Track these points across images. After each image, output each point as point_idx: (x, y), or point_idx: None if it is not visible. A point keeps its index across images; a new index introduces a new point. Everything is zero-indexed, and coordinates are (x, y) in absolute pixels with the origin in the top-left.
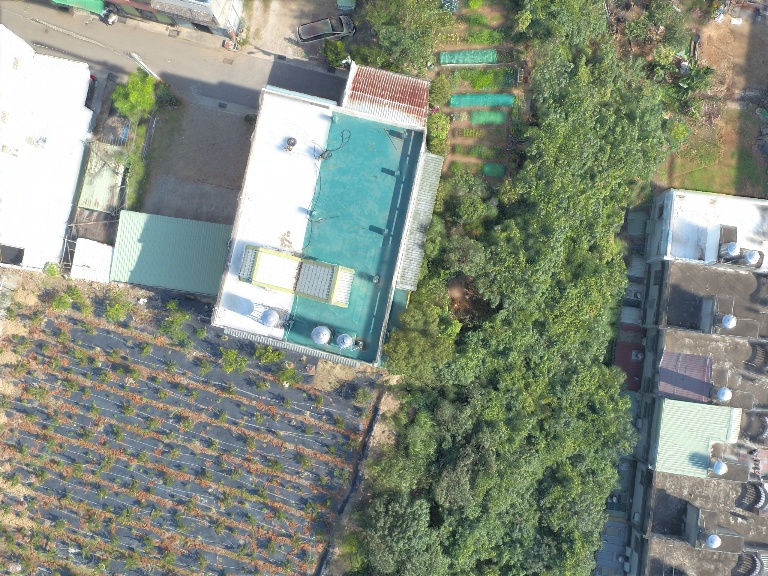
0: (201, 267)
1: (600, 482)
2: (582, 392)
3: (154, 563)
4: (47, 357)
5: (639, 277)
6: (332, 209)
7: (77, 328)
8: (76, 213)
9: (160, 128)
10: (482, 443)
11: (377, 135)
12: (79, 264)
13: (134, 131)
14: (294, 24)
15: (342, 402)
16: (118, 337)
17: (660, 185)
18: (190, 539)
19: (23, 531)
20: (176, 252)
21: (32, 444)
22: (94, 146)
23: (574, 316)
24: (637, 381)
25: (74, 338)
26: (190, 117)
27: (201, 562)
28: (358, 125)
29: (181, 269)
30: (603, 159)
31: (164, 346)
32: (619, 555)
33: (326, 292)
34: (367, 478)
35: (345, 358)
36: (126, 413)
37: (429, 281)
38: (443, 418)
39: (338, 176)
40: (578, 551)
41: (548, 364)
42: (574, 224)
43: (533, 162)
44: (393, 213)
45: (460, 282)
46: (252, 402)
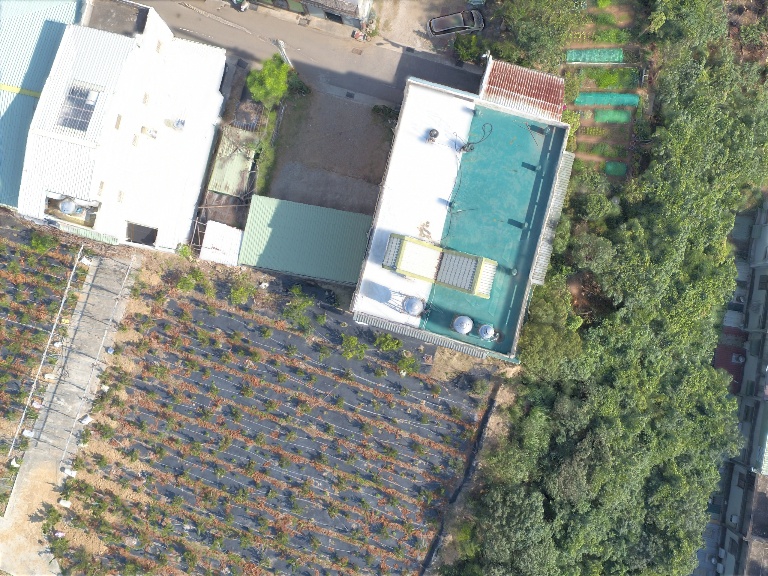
0: (329, 254)
1: (704, 483)
2: (691, 393)
3: (267, 543)
4: (169, 336)
5: (742, 281)
6: (471, 201)
7: (199, 309)
8: (206, 196)
9: (288, 115)
10: (600, 439)
11: (518, 130)
12: (208, 246)
13: (267, 117)
14: (423, 17)
15: (458, 393)
16: (239, 320)
17: (763, 190)
18: (303, 521)
19: (140, 506)
20: (305, 238)
21: (151, 421)
22: (226, 131)
23: (687, 317)
24: (737, 384)
25: (196, 319)
26: (318, 105)
27: (315, 544)
28: (500, 119)
29: (309, 255)
30: (721, 162)
31: (284, 330)
32: (712, 556)
33: (469, 283)
34: (480, 469)
35: (482, 349)
36: (245, 395)
37: (552, 276)
38: (563, 412)
39: (478, 169)
40: (685, 550)
41: (661, 363)
42: (695, 225)
43: (659, 162)
44: (532, 207)
45: (578, 279)
46: (369, 389)
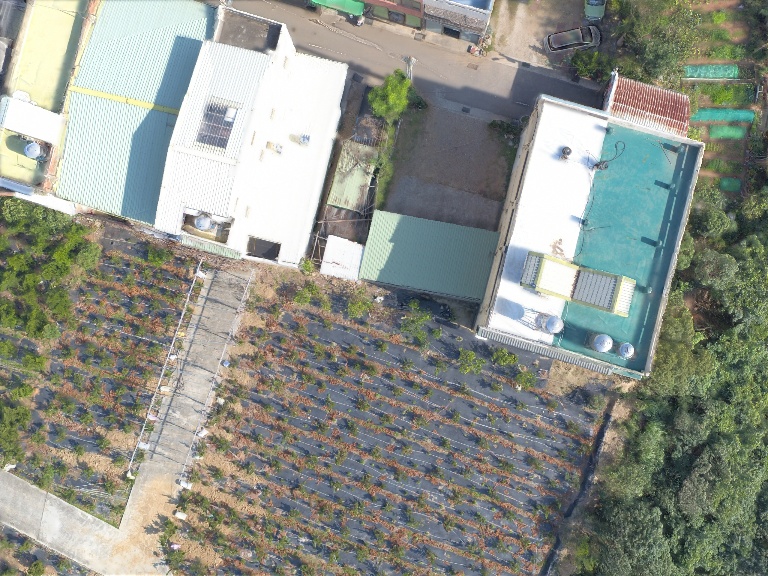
0: (450, 269)
1: None
2: None
3: (382, 556)
4: (284, 350)
5: None
6: (604, 219)
7: (314, 323)
8: (325, 210)
9: (404, 130)
10: (719, 454)
11: (651, 148)
12: (329, 261)
13: (387, 132)
14: (539, 32)
15: (573, 407)
16: (354, 333)
17: None
18: (418, 534)
19: (256, 519)
20: (426, 253)
21: (267, 434)
22: (346, 145)
23: None
24: None
25: (311, 332)
26: (433, 120)
27: (432, 557)
28: (632, 137)
29: (430, 270)
30: None
31: (399, 344)
32: None
33: (608, 301)
34: (596, 483)
35: (617, 366)
36: (361, 408)
37: (672, 292)
38: (683, 428)
39: (611, 187)
40: None
41: None
42: None
43: None
44: (665, 225)
45: (692, 294)
46: (484, 403)
